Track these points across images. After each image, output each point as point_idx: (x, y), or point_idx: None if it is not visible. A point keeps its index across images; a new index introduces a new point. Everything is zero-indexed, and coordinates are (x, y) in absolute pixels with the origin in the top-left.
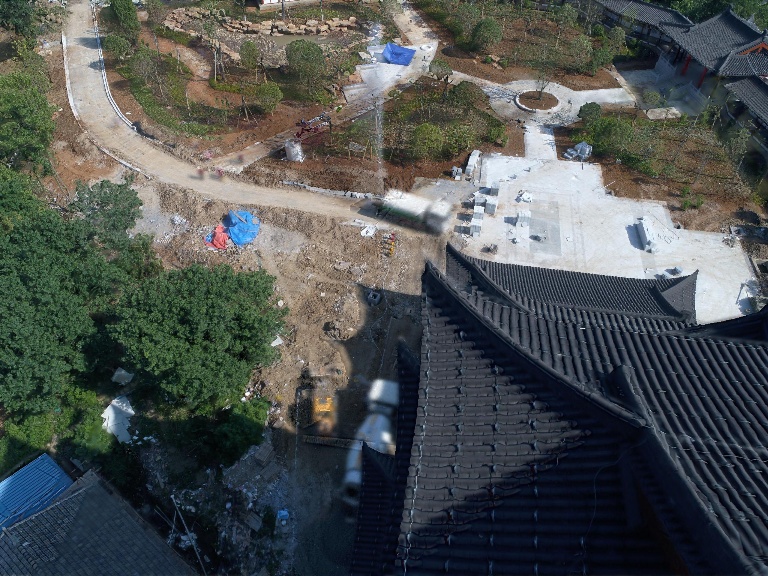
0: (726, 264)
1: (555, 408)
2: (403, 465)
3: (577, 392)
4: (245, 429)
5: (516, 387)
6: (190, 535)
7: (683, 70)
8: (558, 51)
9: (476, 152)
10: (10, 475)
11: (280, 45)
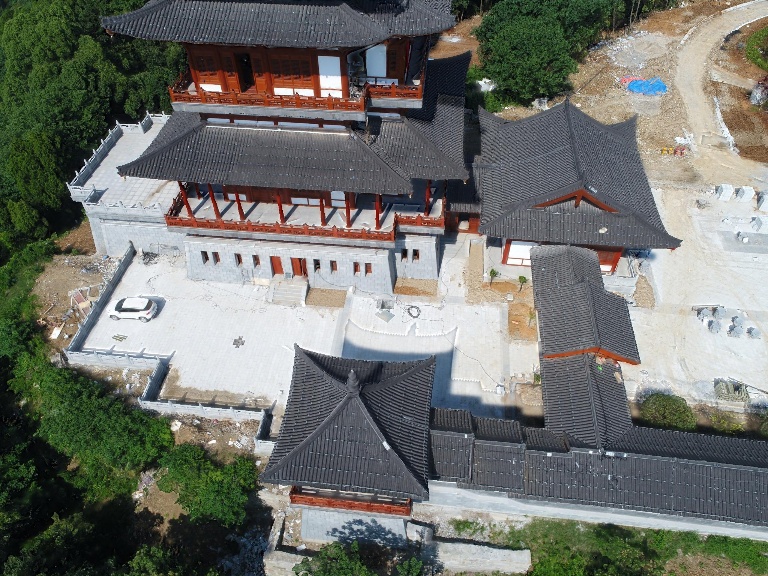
0: None
1: None
2: None
3: None
4: (476, 97)
5: None
6: None
7: None
8: None
9: None
10: None
11: None
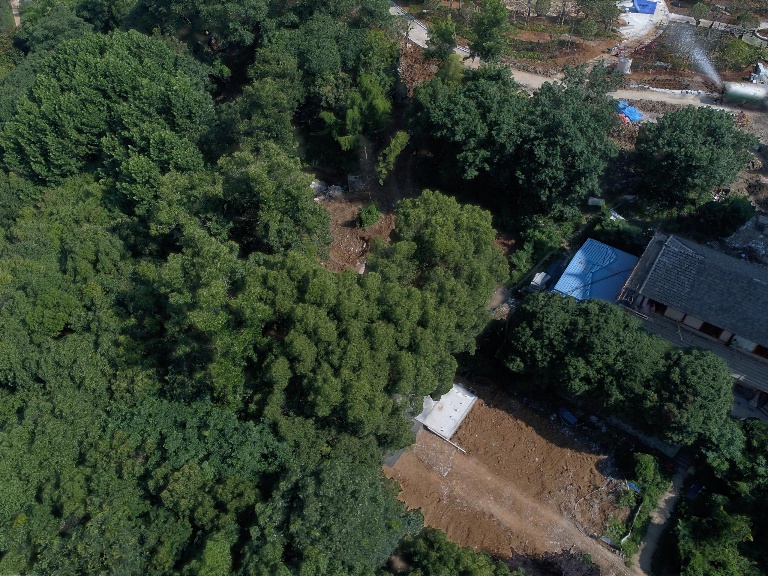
0: None
1: None
2: None
3: None
4: None
5: None
6: None
7: None
8: (766, 2)
9: (761, 64)
10: (545, 263)
11: (534, 3)
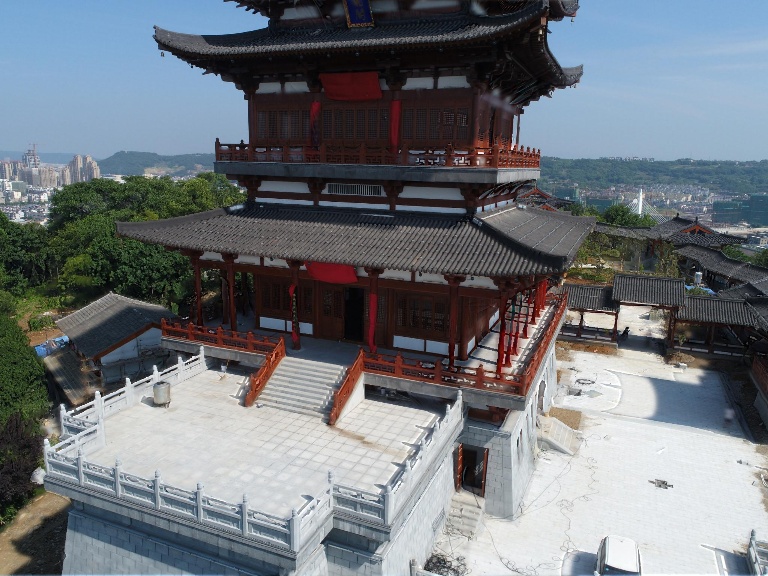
0: (640, 307)
1: None
2: None
3: None
4: None
5: None
6: None
7: (651, 255)
8: None
9: None
10: None
11: None
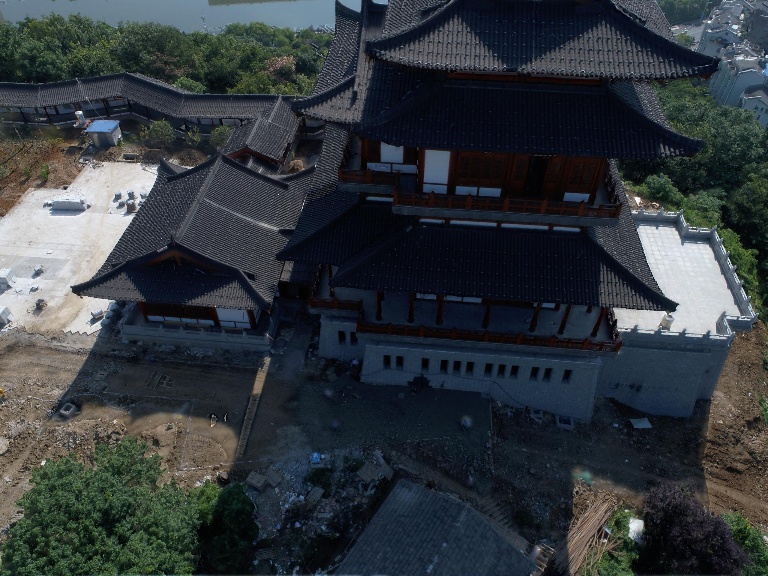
0: (120, 172)
1: (444, 24)
2: (421, 141)
3: (443, 11)
4: (235, 491)
5: (431, 35)
6: (317, 575)
7: None
8: None
9: None
10: None
11: None
